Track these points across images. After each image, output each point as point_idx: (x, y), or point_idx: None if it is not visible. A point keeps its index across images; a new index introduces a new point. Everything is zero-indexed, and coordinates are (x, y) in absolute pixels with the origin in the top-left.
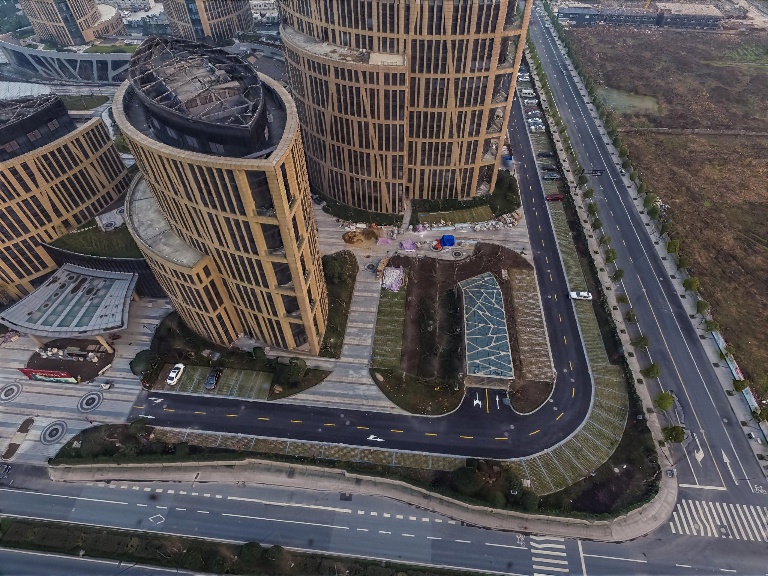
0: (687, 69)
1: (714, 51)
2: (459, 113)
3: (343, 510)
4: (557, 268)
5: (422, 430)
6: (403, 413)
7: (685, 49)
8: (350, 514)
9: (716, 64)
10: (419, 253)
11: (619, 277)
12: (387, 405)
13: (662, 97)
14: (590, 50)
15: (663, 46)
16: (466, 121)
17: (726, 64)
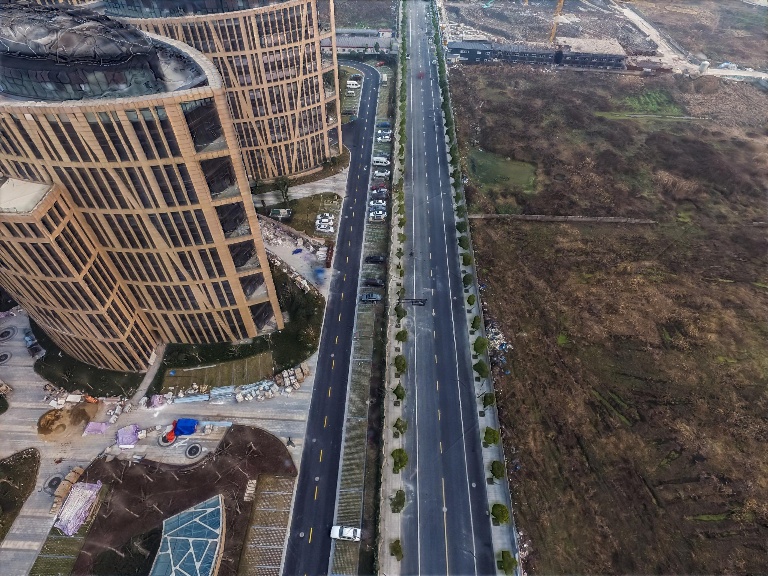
0: (577, 124)
1: (613, 98)
2: (180, 253)
3: None
4: (330, 472)
5: None
6: None
7: (581, 96)
8: None
9: (612, 116)
10: (138, 451)
11: (399, 506)
12: None
13: (541, 165)
14: (474, 97)
15: (556, 93)
16: (196, 261)
17: (624, 116)
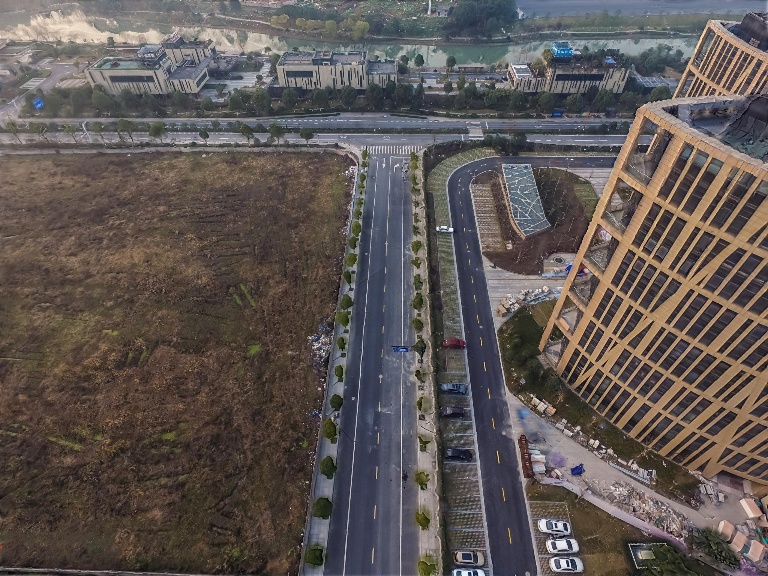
0: None
1: None
2: None
3: (571, 144)
4: (461, 254)
5: (546, 163)
6: (559, 168)
7: None
8: (567, 143)
9: None
10: None
11: None
12: (570, 170)
13: None
14: None
15: None
16: None
17: None
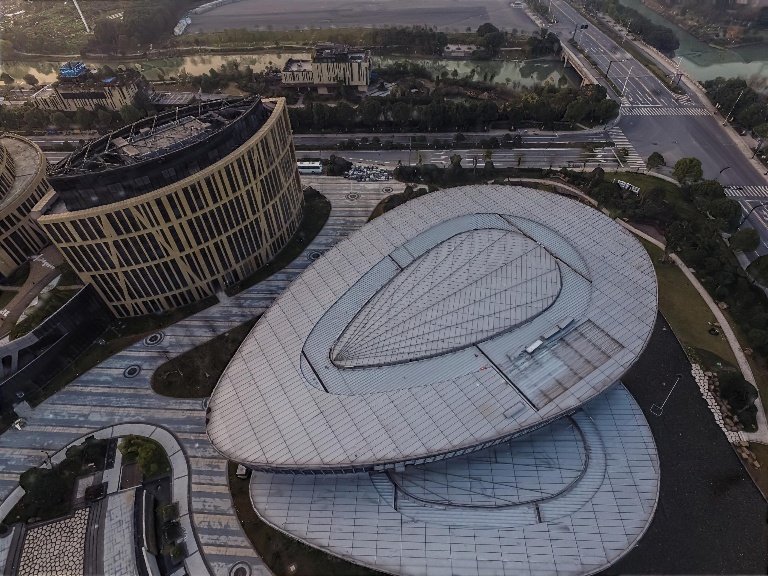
0: None
1: None
2: None
3: None
4: None
5: None
6: None
7: None
8: None
9: None
10: None
11: None
12: None
13: None
14: None
15: None
16: None
17: None
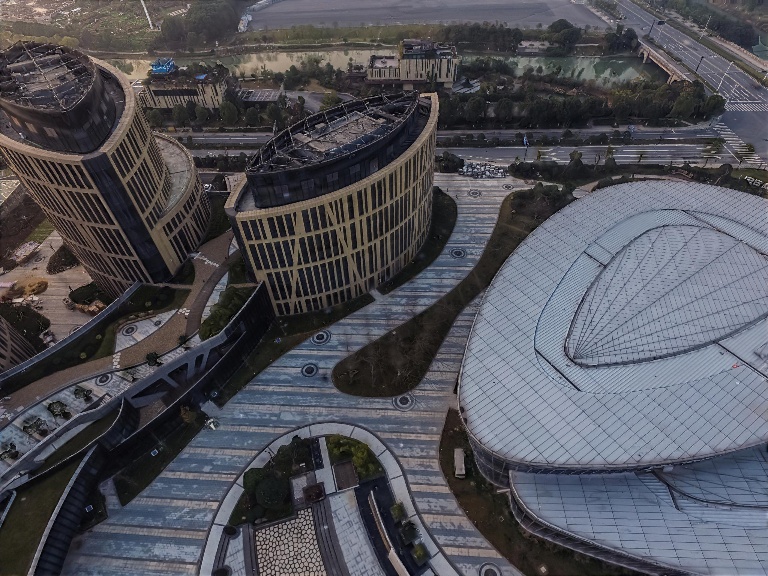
0: None
1: None
2: None
3: None
4: None
5: None
6: None
7: None
8: None
9: None
10: None
11: None
12: None
13: None
14: None
15: None
16: None
17: None
